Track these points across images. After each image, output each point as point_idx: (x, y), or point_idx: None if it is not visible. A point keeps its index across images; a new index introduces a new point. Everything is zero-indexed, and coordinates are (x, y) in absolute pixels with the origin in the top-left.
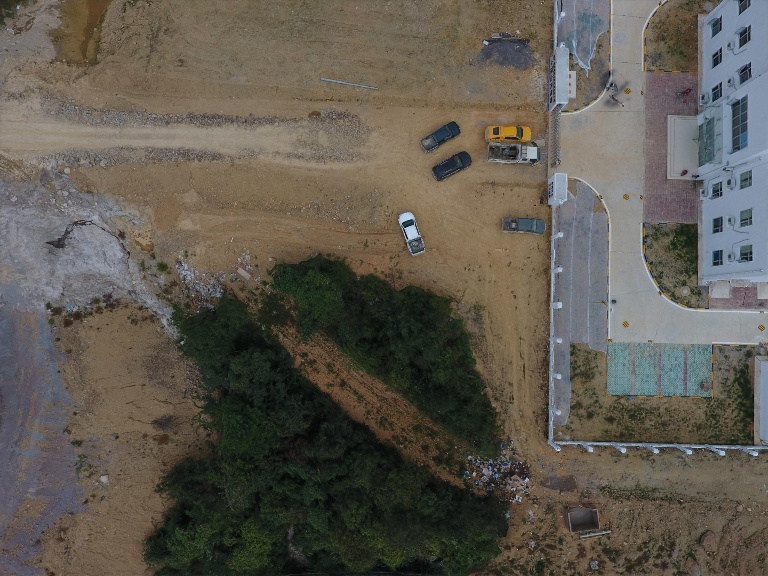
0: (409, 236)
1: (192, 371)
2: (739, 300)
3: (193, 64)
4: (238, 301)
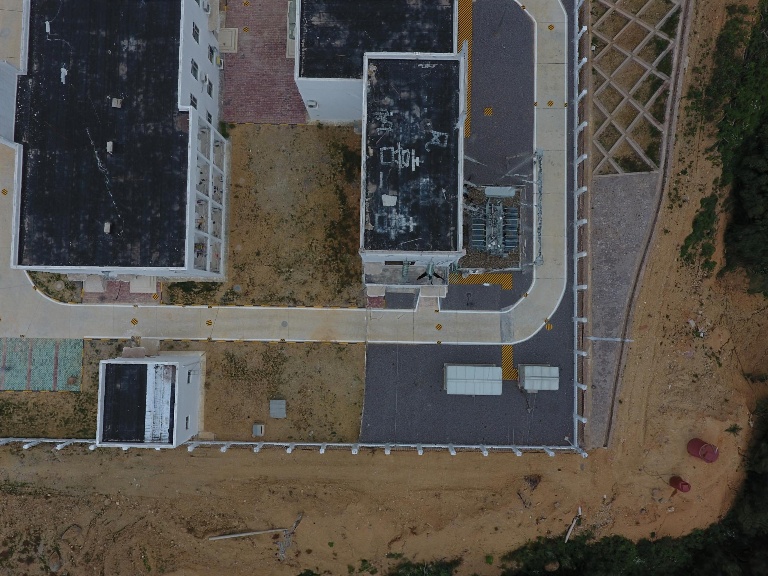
0: None
1: None
2: (113, 294)
3: None
4: None
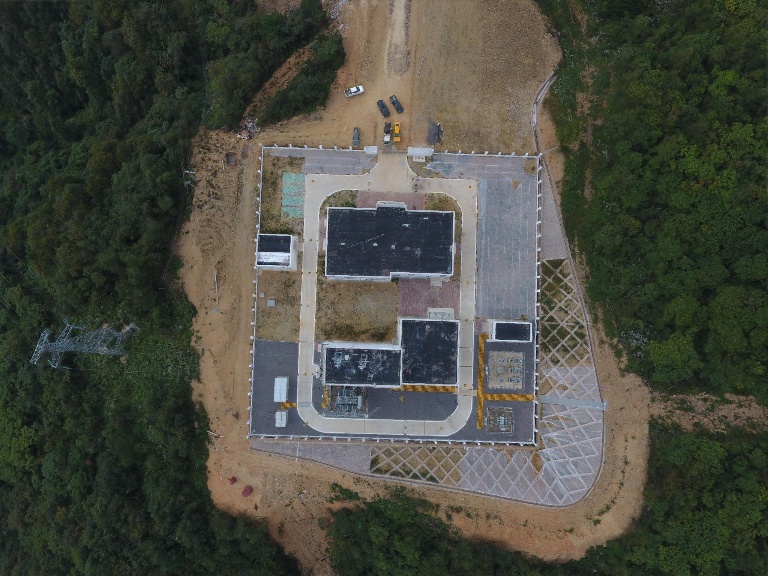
0: (352, 88)
1: (298, 8)
2: (323, 231)
3: (432, 0)
4: (329, 25)
